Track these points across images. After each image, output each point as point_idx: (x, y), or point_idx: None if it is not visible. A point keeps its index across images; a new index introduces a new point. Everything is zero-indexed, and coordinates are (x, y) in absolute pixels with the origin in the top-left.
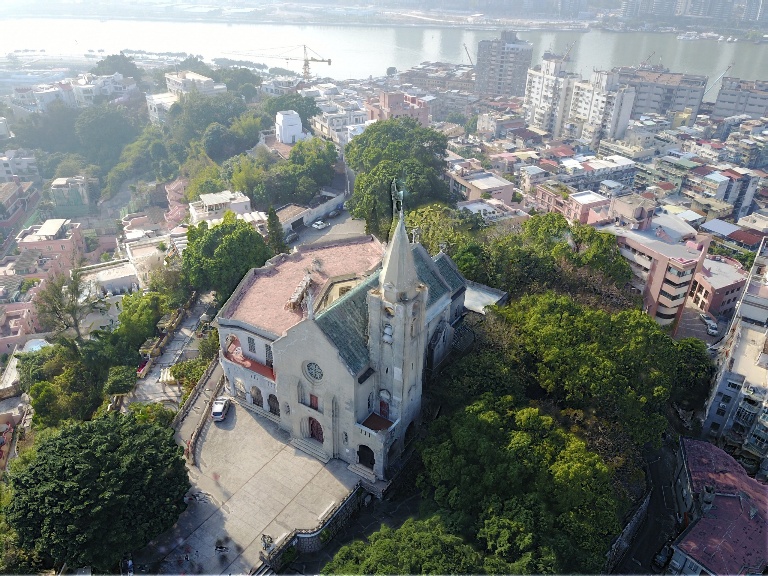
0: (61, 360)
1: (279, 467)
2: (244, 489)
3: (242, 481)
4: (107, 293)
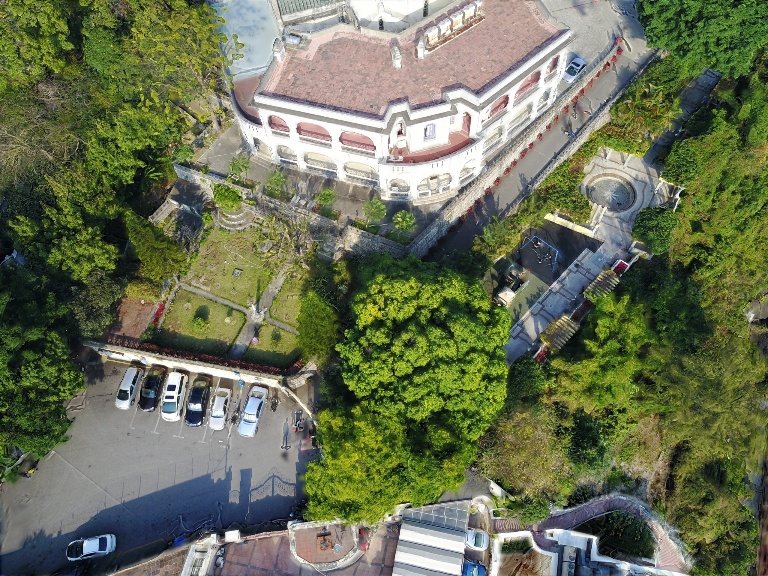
0: (713, 488)
1: (550, 3)
2: (586, 0)
3: (584, 7)
4: (629, 570)
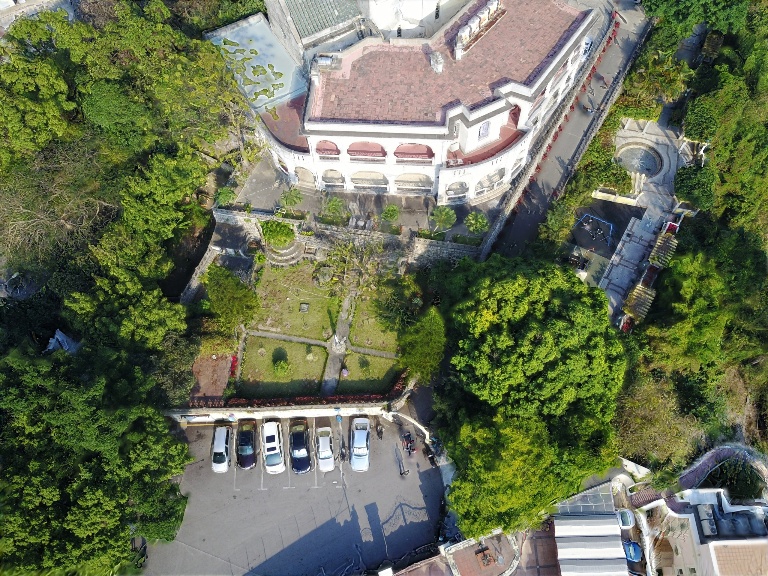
0: None
1: None
2: None
3: None
4: None
